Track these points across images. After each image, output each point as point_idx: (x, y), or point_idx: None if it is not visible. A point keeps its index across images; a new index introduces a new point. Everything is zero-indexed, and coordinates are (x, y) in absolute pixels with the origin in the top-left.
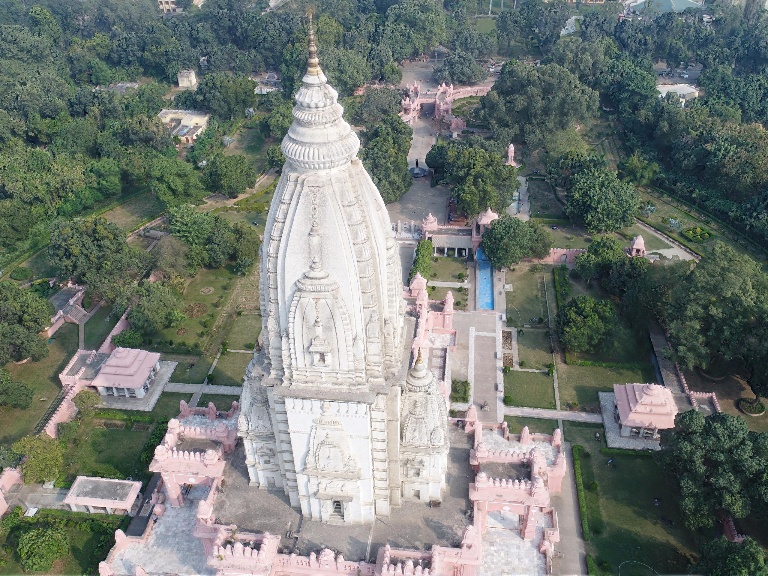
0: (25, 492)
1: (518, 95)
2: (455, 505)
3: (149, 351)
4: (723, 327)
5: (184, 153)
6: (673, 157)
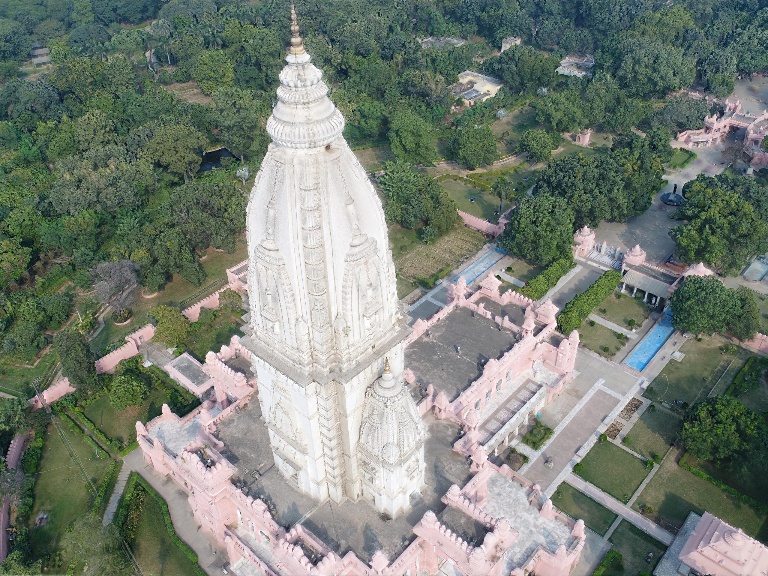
0: (155, 348)
1: None
2: (403, 529)
3: None
4: None
5: (460, 116)
6: None
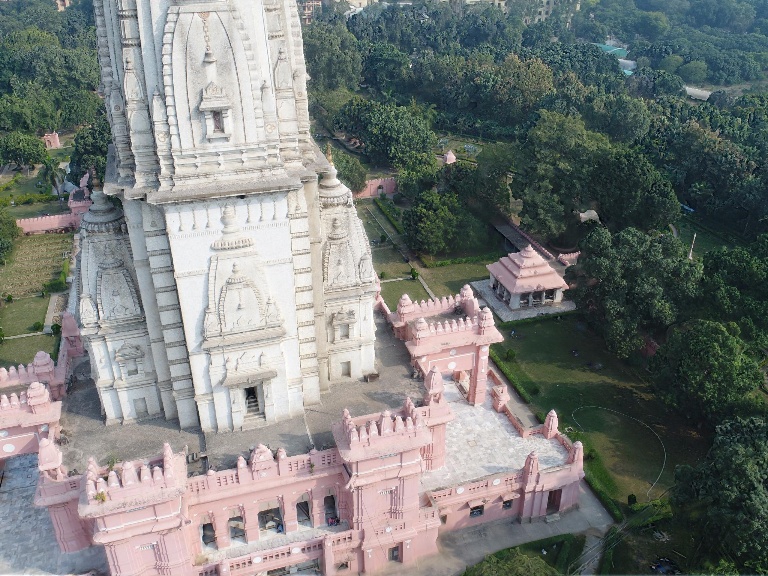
0: None
1: None
2: (395, 373)
3: None
4: (573, 181)
5: None
6: (446, 100)
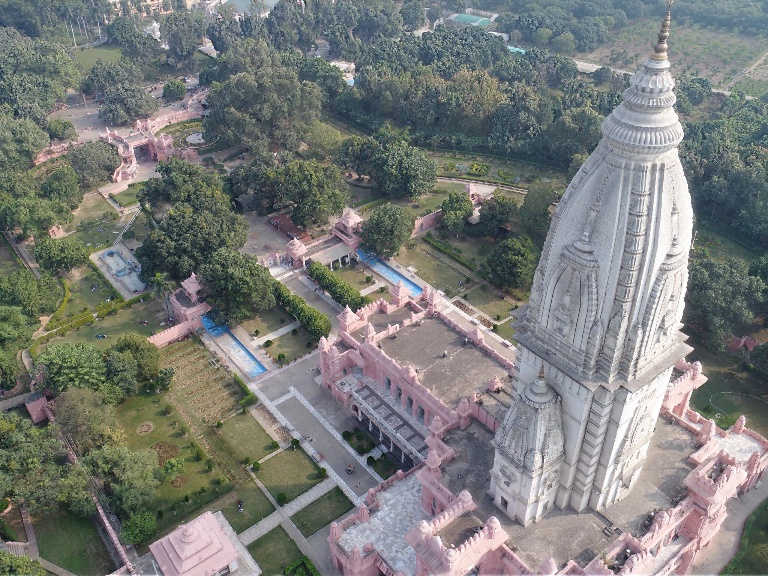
0: None
1: (259, 105)
2: (657, 423)
3: (171, 524)
4: None
5: None
6: (412, 118)
